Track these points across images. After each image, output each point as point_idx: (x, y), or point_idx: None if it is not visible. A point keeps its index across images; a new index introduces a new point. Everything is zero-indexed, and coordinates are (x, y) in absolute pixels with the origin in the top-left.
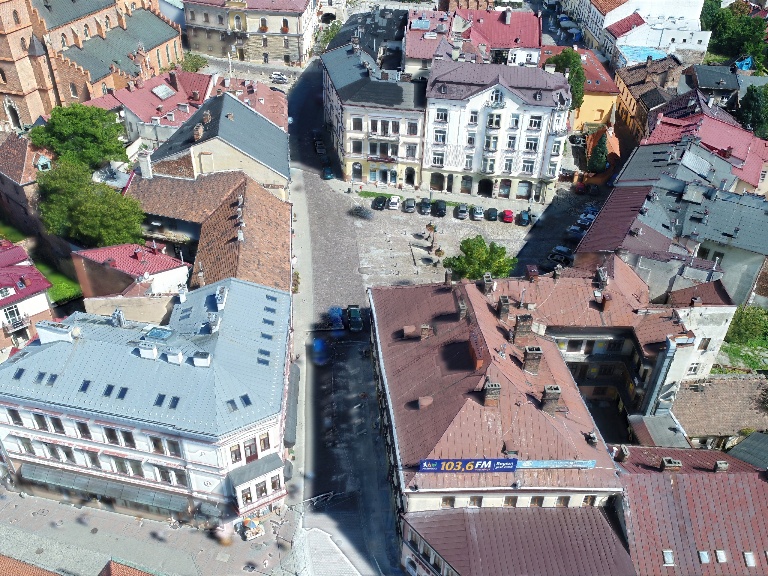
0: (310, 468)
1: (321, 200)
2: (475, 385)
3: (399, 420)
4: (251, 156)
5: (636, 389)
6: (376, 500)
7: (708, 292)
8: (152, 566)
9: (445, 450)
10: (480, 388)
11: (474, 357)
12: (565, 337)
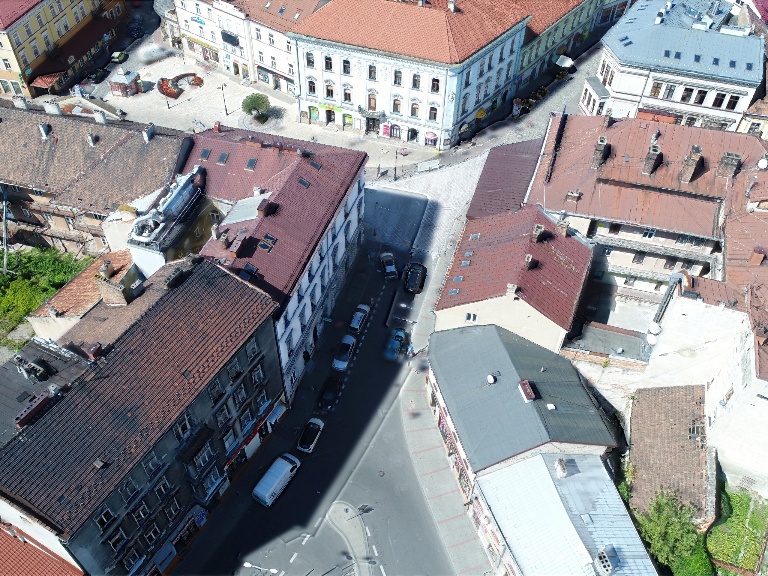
0: None
1: None
2: None
3: None
4: None
5: None
6: None
7: None
8: (568, 103)
9: None
10: None
11: None
12: None
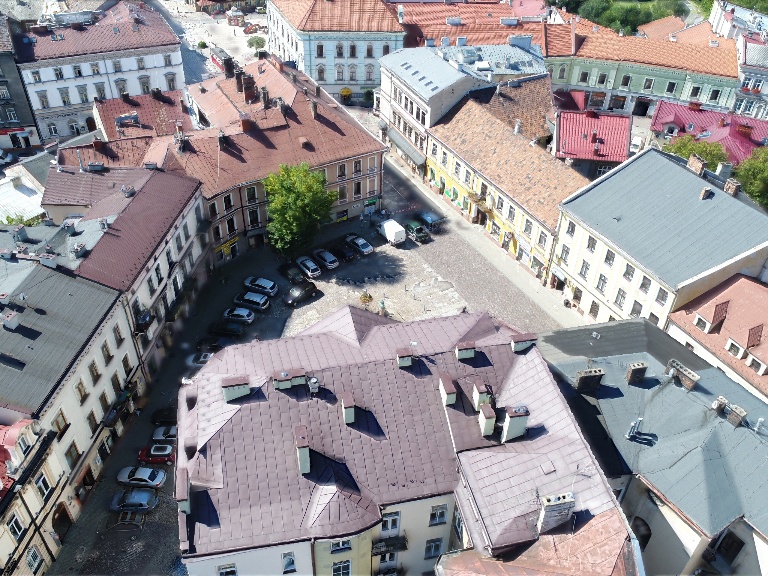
0: None
1: None
2: None
3: None
4: (610, 173)
5: None
6: None
7: None
8: None
9: None
10: None
11: None
12: None
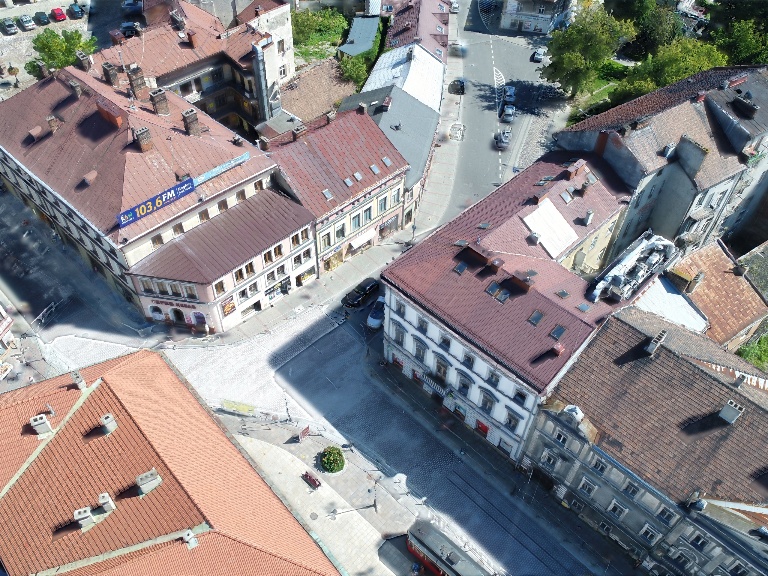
0: (17, 301)
1: None
2: (126, 140)
3: (77, 204)
4: None
5: (250, 101)
6: (95, 291)
7: (264, 2)
8: None
9: (132, 202)
10: (131, 140)
11: (111, 119)
12: (175, 83)
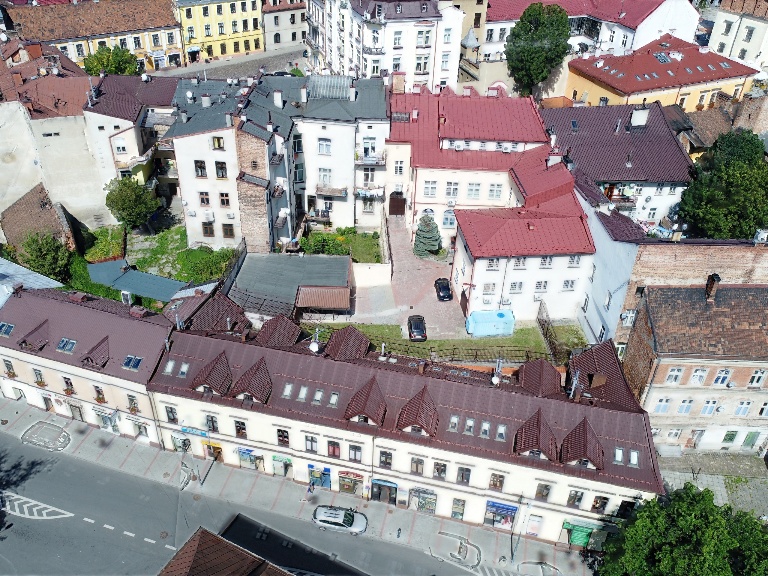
0: None
1: (269, 61)
2: None
3: None
4: None
5: None
6: None
7: None
8: None
9: None
10: None
11: None
12: None
